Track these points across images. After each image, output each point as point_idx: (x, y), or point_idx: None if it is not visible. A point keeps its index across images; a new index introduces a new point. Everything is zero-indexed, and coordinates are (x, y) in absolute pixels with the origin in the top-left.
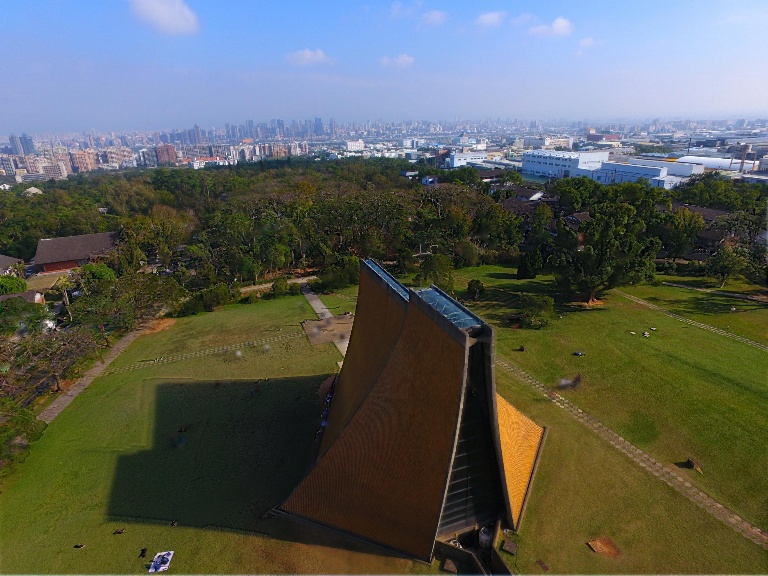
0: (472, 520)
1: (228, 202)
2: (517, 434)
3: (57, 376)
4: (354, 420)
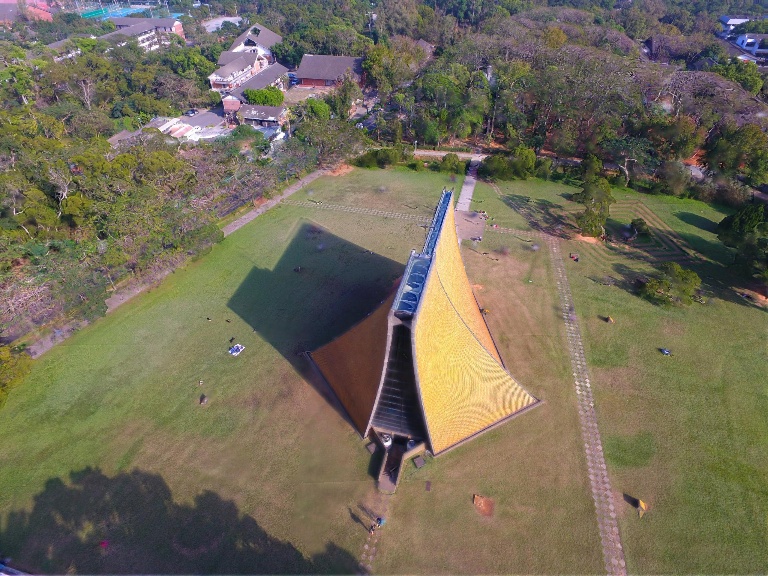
0: (406, 431)
1: (459, 45)
2: (490, 394)
3: (252, 196)
4: (360, 325)
